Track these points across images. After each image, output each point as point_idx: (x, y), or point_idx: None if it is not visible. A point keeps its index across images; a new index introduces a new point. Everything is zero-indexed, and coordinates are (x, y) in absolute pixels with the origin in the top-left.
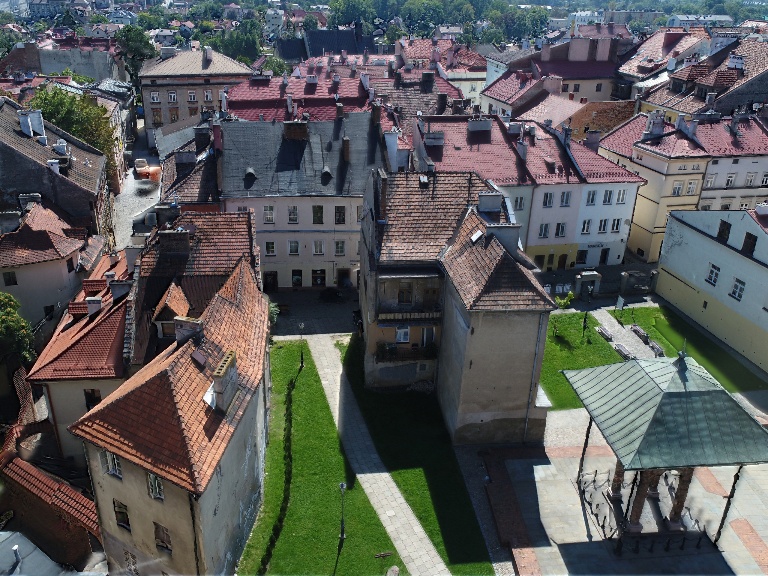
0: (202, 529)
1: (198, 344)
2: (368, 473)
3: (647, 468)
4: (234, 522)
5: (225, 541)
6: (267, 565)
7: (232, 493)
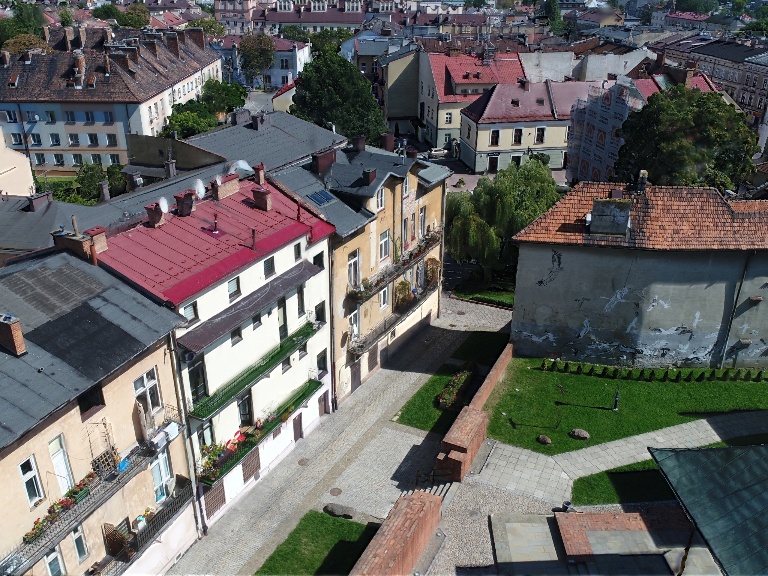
0: (518, 275)
1: (631, 190)
2: (711, 426)
3: (660, 466)
4: (570, 323)
5: (549, 320)
6: (568, 373)
7: (575, 298)
